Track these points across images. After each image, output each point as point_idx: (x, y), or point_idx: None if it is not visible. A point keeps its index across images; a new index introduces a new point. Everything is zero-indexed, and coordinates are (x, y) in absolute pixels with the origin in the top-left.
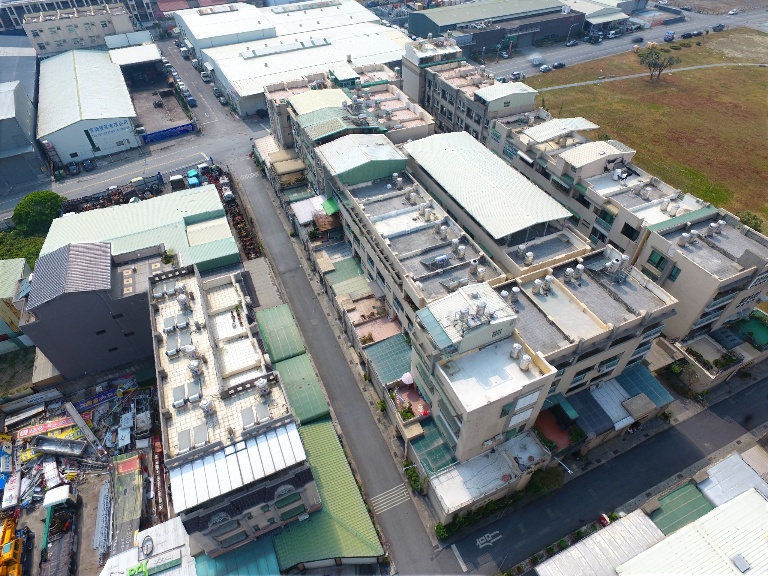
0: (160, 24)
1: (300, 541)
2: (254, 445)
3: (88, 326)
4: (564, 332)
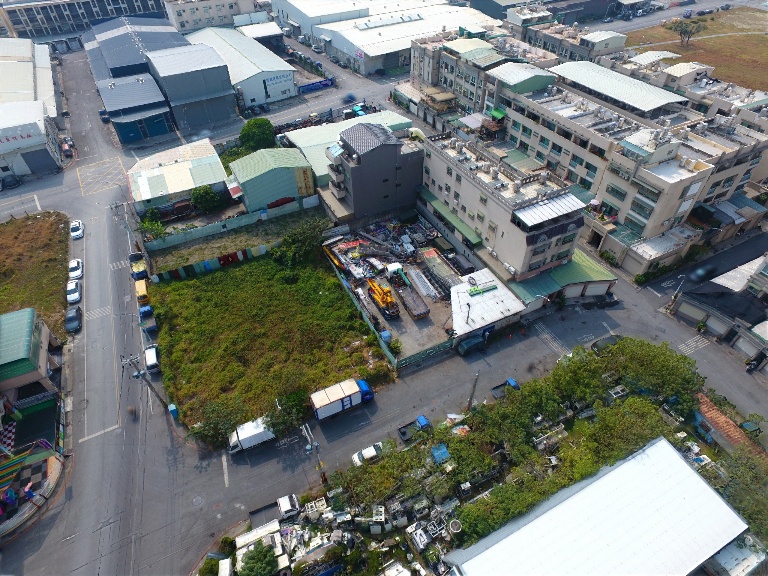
0: None
1: (565, 275)
2: (553, 201)
3: (382, 174)
4: (708, 153)
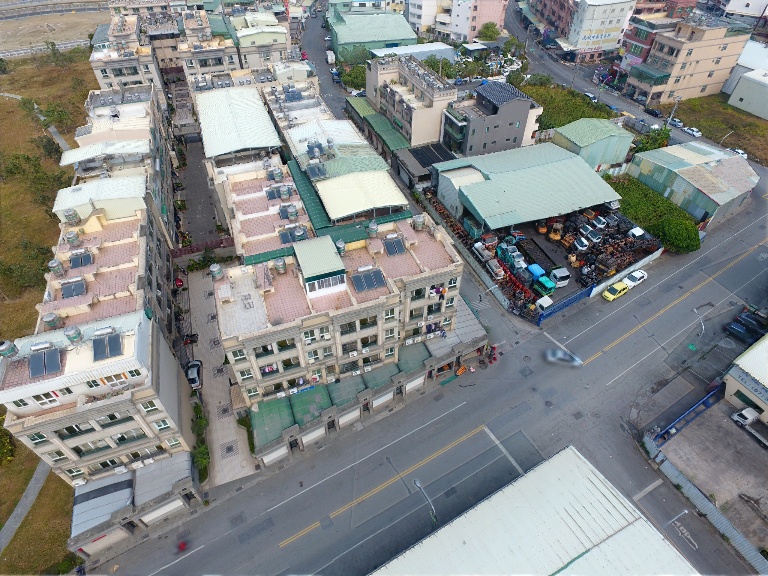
0: None
1: None
2: None
3: None
4: None
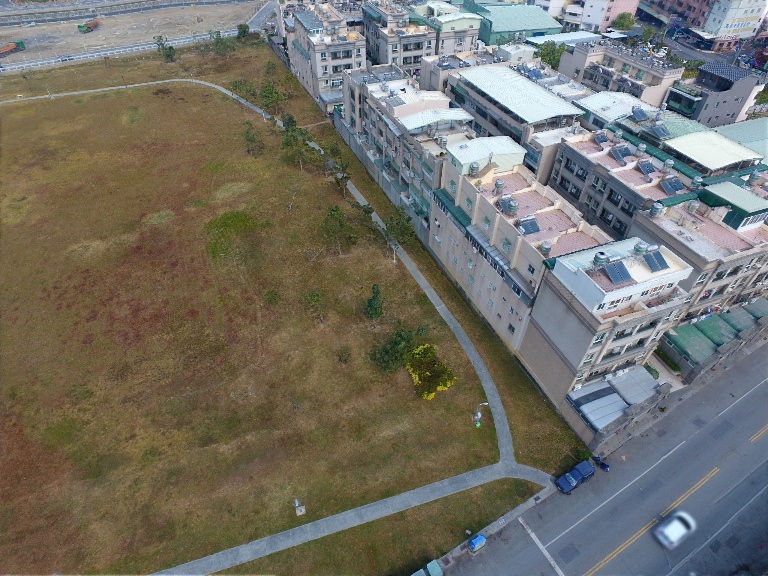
0: None
1: None
2: None
3: None
4: None
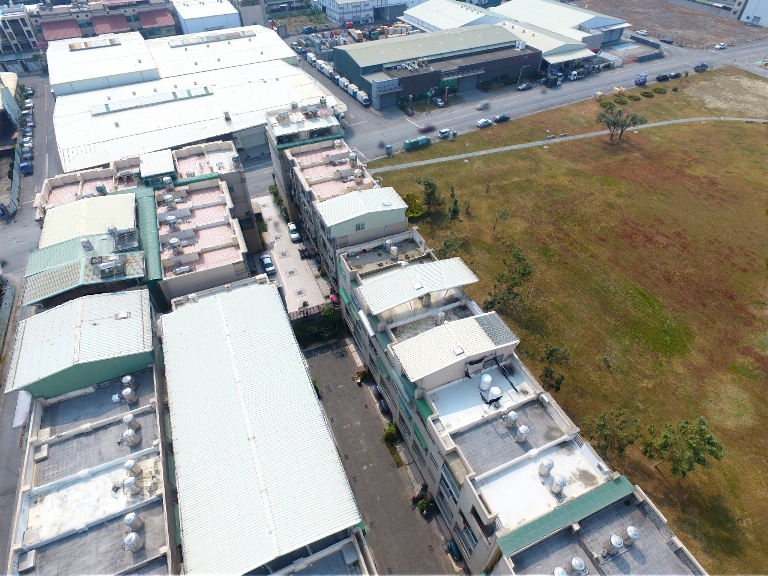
0: (41, 56)
1: None
2: None
3: None
4: None
